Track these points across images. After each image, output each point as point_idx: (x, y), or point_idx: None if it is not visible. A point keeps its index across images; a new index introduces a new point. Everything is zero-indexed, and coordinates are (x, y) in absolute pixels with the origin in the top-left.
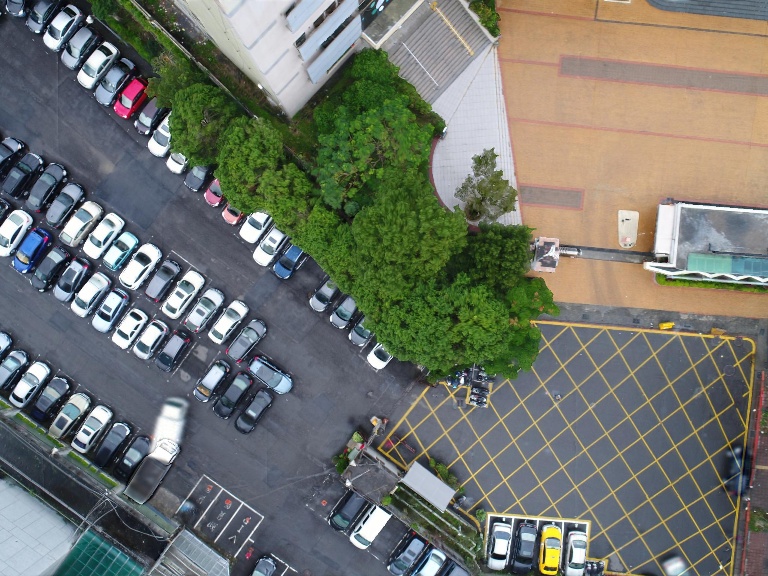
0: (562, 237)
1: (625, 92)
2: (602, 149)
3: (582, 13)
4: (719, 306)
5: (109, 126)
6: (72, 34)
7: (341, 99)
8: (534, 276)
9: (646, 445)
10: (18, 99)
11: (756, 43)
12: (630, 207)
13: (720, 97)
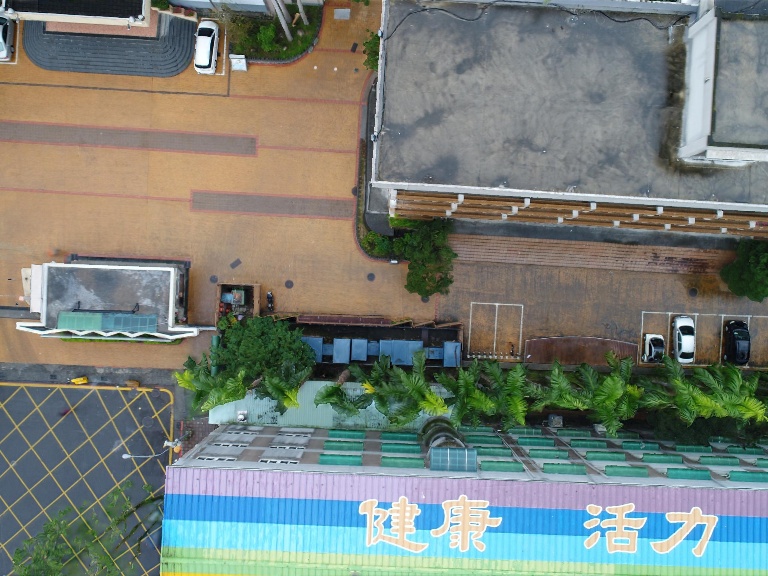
0: None
1: (18, 152)
2: (1, 209)
3: None
4: (133, 359)
5: None
6: None
7: None
8: None
9: (69, 500)
10: None
11: (143, 99)
12: None
13: (113, 153)
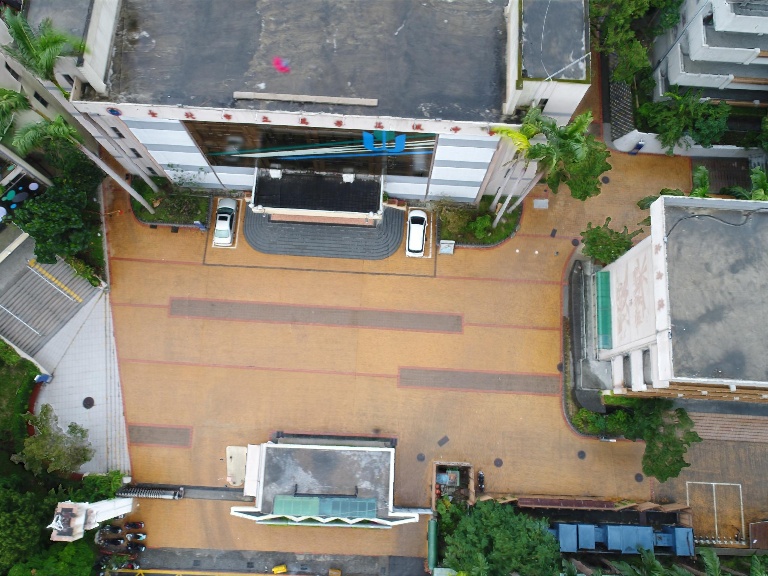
0: (171, 477)
1: (232, 329)
2: (210, 385)
3: (191, 259)
4: (335, 544)
5: None
6: None
7: None
8: (141, 520)
9: None
10: None
11: (354, 280)
12: (239, 442)
13: (323, 331)
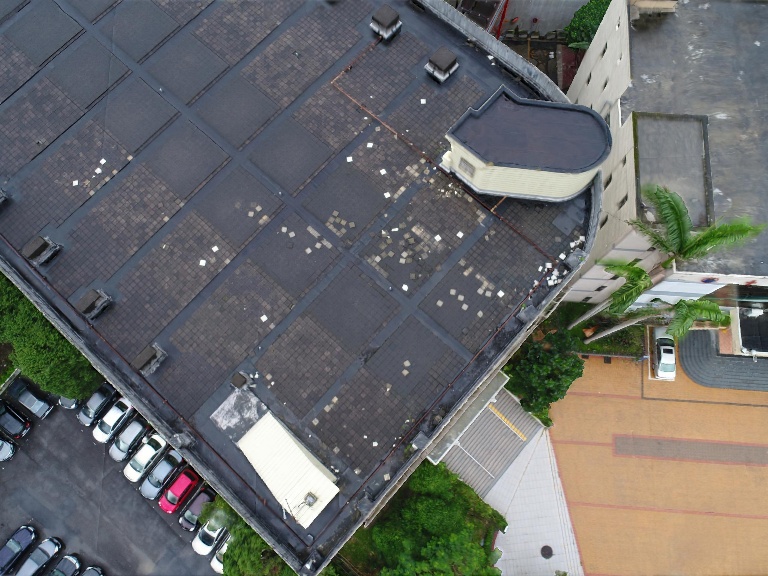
0: None
1: (684, 471)
2: (669, 533)
3: (629, 392)
4: None
5: (152, 520)
6: (122, 425)
7: (401, 516)
8: None
9: None
10: (60, 493)
11: None
12: None
13: None
